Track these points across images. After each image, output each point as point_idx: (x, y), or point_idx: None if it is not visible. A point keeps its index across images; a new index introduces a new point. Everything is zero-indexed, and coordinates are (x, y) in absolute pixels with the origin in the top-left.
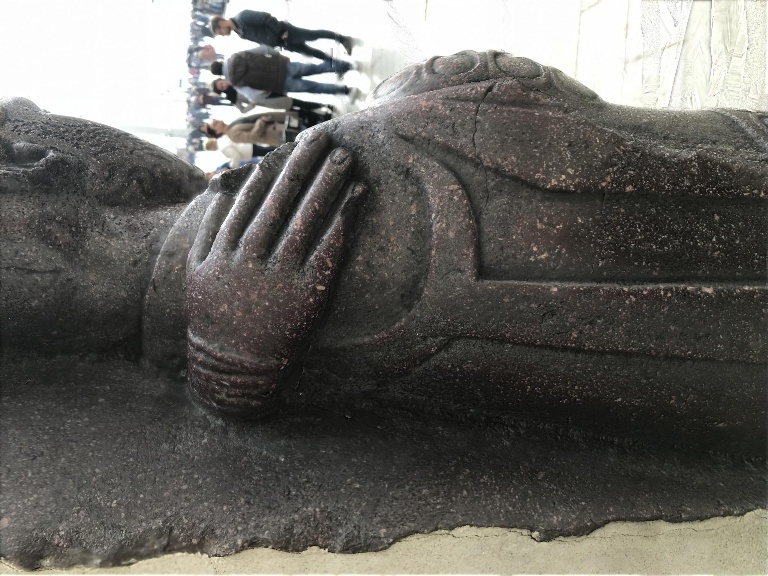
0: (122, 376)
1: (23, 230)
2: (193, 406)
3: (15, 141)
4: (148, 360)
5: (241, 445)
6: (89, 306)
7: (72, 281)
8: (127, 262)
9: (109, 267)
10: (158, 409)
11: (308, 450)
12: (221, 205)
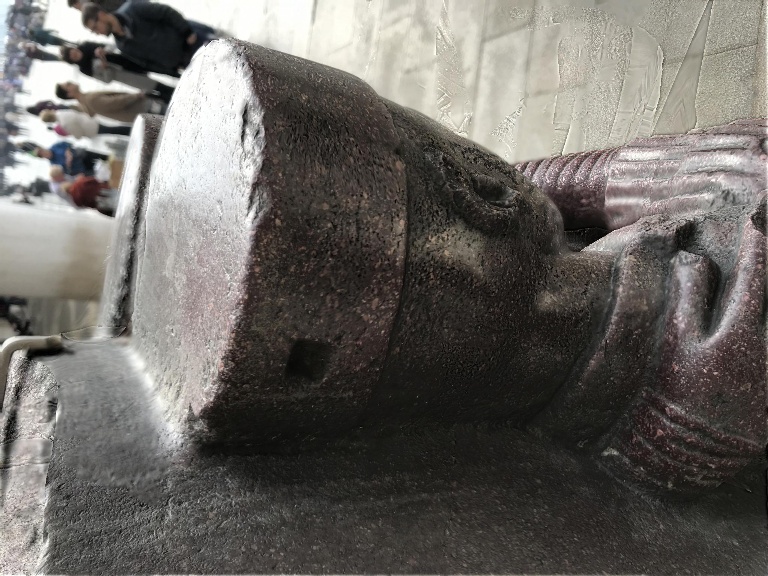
0: (527, 448)
1: (497, 282)
2: (621, 484)
3: (473, 171)
4: (541, 428)
5: (695, 530)
6: (520, 370)
7: (515, 341)
8: (569, 321)
9: (552, 326)
10: (594, 490)
11: (750, 532)
12: (708, 269)
